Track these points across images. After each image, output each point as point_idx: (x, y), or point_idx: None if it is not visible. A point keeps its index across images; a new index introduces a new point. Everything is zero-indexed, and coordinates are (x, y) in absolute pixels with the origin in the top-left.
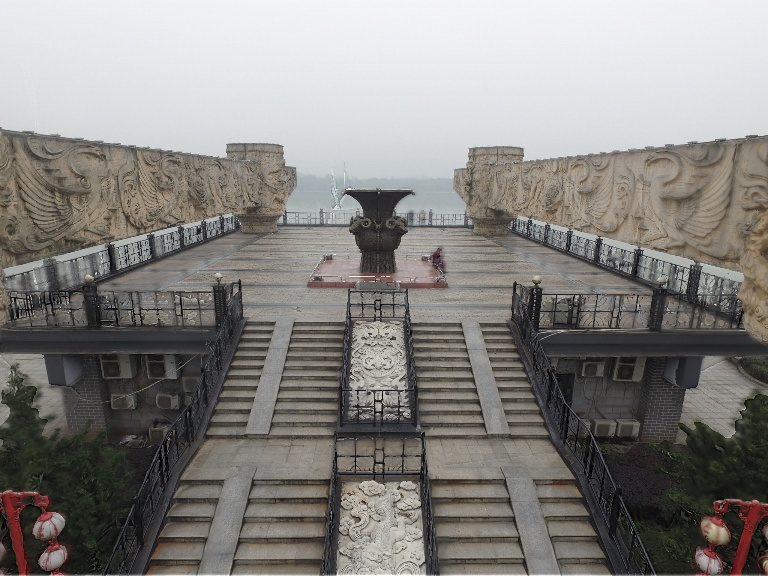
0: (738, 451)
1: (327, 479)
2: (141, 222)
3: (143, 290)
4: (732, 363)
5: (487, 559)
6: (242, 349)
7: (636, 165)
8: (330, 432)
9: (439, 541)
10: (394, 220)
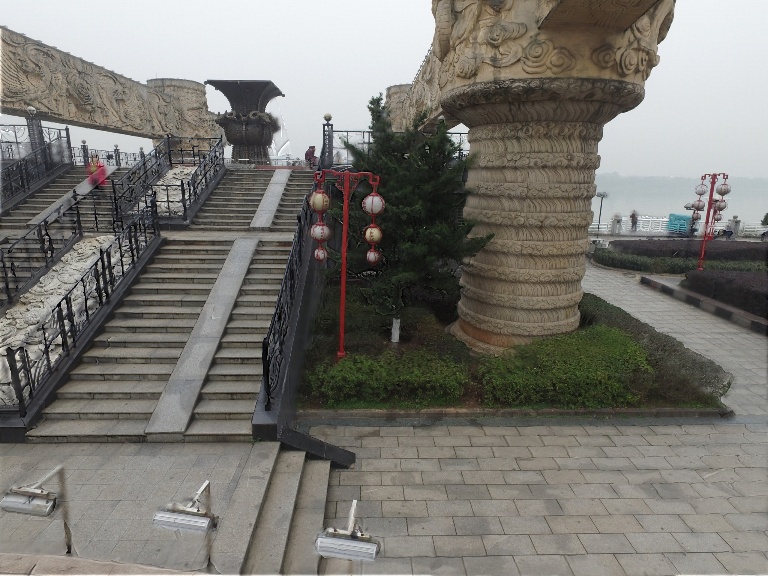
0: (368, 159)
1: None
2: None
3: None
4: (588, 258)
5: (185, 278)
6: (60, 183)
7: None
8: (107, 225)
9: (152, 271)
10: (257, 111)
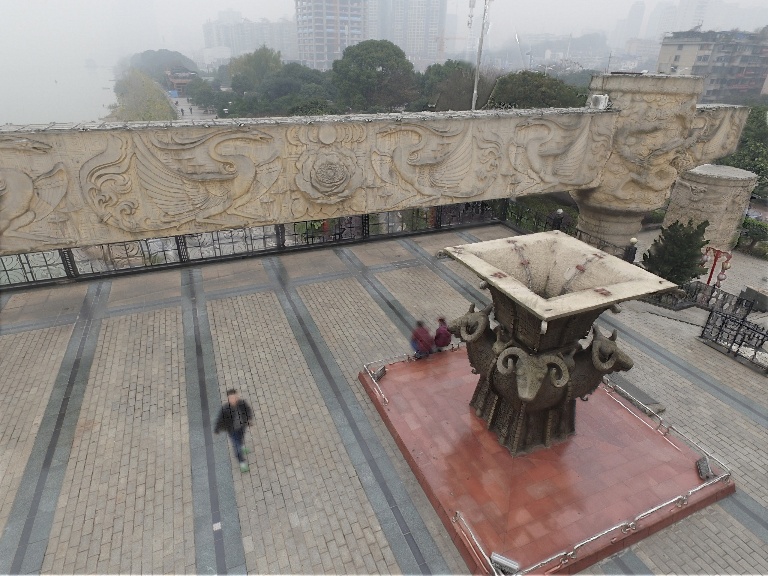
0: None
1: None
2: None
3: None
4: None
5: None
6: None
7: (505, 130)
8: None
9: None
10: None
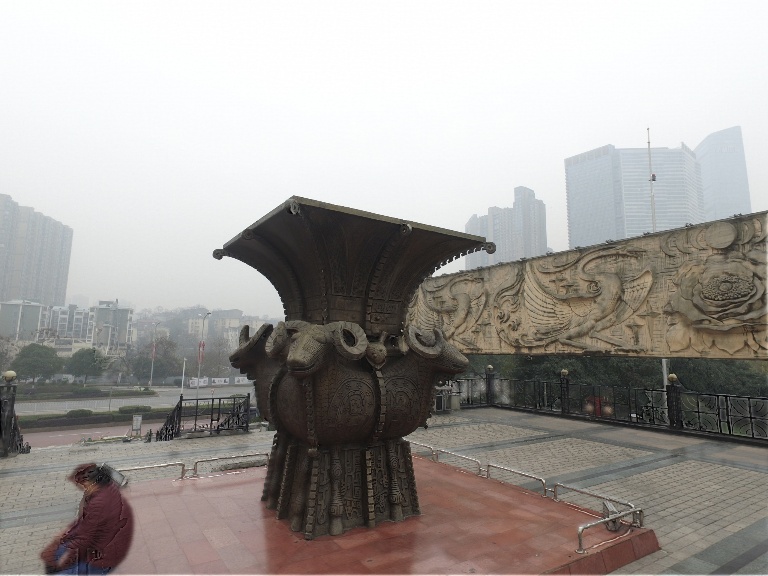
0: None
1: None
2: None
3: None
4: None
5: None
6: None
7: None
8: None
9: None
10: None
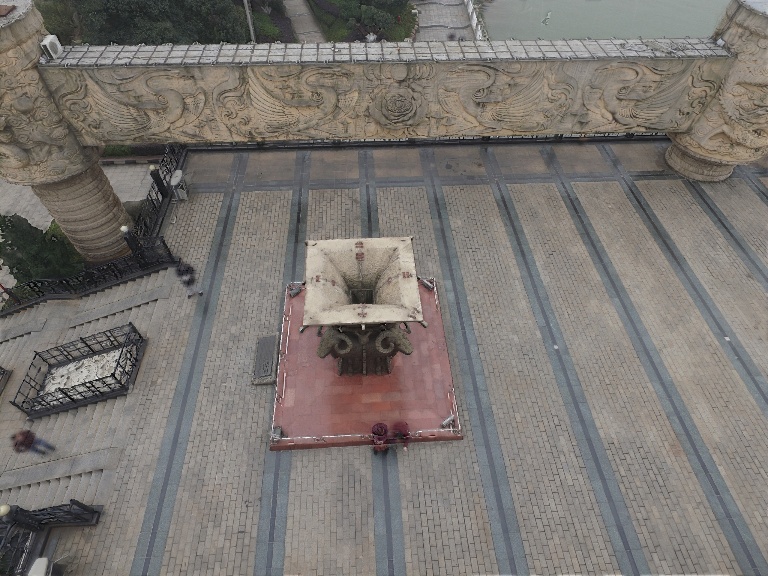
0: None
1: (13, 368)
2: (252, 132)
3: (280, 180)
4: None
5: None
6: None
7: None
8: None
9: None
10: (318, 329)
